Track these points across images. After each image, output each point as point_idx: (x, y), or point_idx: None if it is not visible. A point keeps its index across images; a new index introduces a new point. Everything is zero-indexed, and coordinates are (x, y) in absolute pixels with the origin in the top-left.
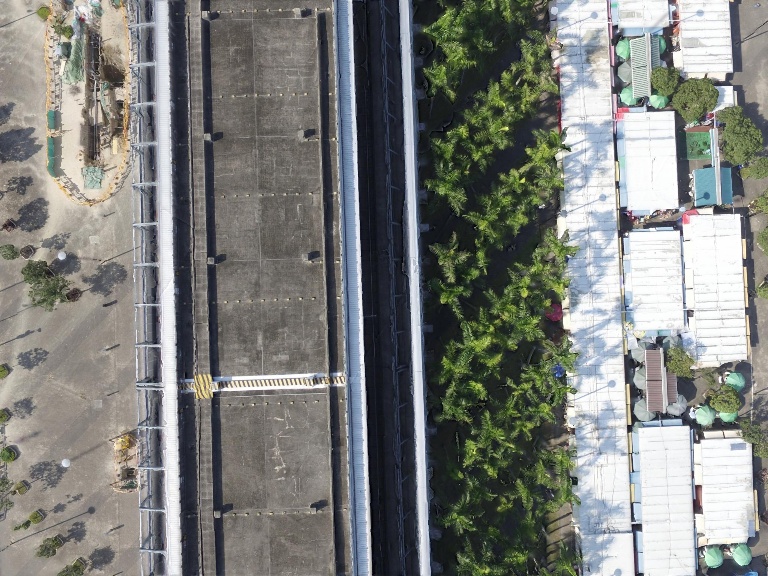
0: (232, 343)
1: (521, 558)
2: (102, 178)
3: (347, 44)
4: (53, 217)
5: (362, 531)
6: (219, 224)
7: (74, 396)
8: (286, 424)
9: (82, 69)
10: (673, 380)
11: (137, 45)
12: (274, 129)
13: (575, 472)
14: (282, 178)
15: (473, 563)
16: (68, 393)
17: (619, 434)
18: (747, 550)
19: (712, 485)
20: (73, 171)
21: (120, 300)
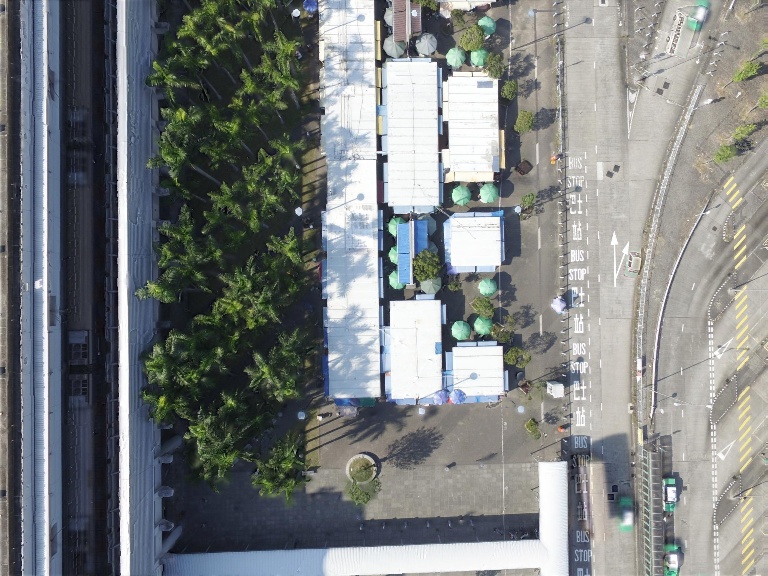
0: None
1: (233, 129)
2: None
3: None
4: None
5: (38, 36)
6: None
7: None
8: None
9: None
10: (417, 10)
11: None
12: None
13: (323, 102)
14: None
15: (173, 113)
16: None
17: (367, 67)
18: (492, 186)
19: (458, 120)
20: None
21: None
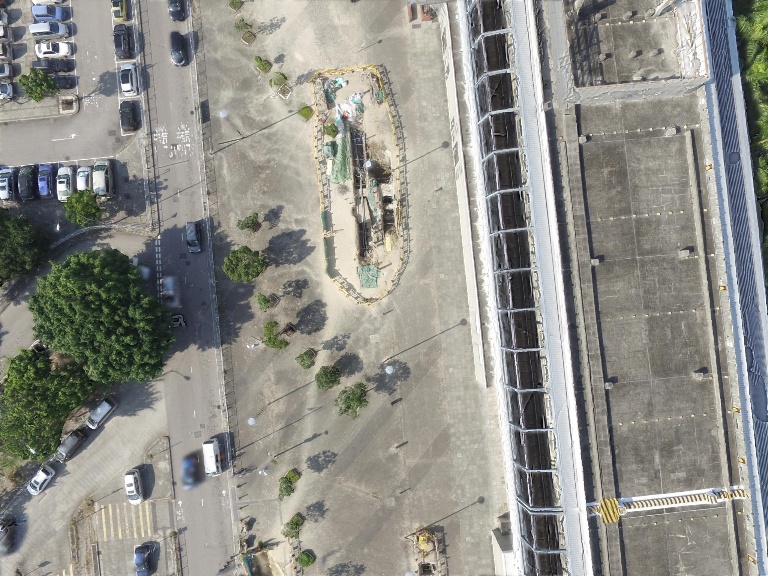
0: (630, 464)
1: None
2: (378, 276)
3: (717, 159)
4: (332, 318)
5: None
6: (607, 347)
7: (366, 496)
8: (688, 540)
9: (349, 167)
10: None
11: (482, 163)
12: (654, 249)
13: None
14: (665, 297)
15: None
16: (359, 493)
17: None
18: None
19: None
20: (348, 271)
21: (405, 397)
